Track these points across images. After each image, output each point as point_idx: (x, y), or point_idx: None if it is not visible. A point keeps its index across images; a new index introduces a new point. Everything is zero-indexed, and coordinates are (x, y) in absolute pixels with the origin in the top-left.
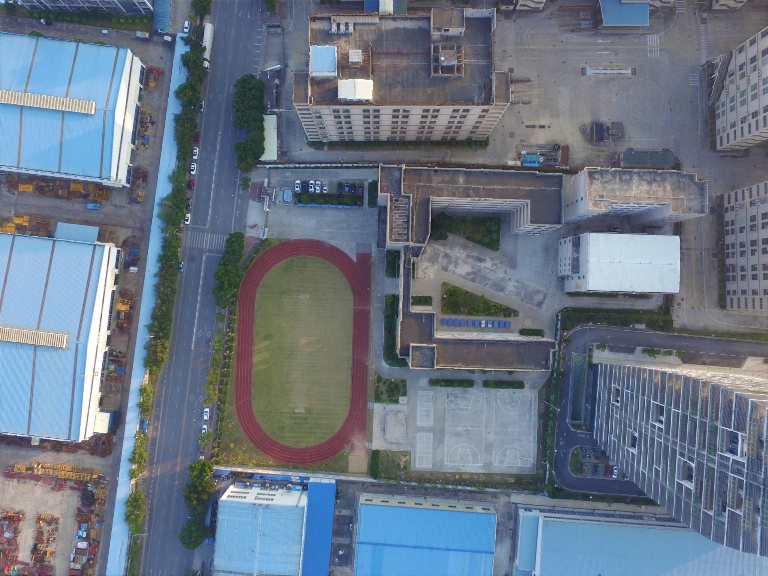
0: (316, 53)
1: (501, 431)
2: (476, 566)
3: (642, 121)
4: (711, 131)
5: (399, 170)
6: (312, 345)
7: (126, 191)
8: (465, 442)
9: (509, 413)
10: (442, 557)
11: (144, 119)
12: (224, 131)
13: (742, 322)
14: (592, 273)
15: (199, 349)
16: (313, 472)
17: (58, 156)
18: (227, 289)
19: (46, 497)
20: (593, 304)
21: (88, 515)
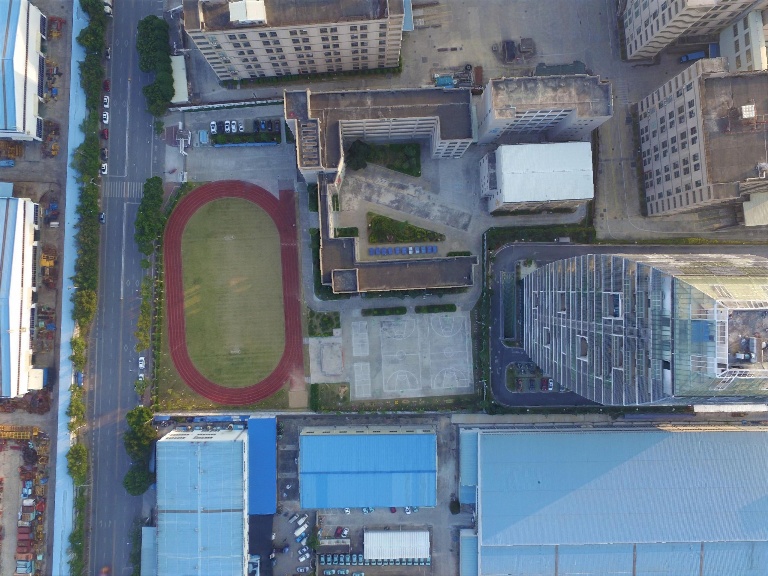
0: None
1: (437, 355)
2: (419, 486)
3: (553, 36)
4: (621, 41)
5: (304, 95)
6: (242, 286)
7: (39, 146)
8: (402, 368)
9: (443, 336)
10: (385, 480)
11: (50, 71)
12: (134, 77)
13: (664, 228)
14: (507, 185)
15: (129, 299)
16: (254, 411)
17: None
18: (149, 234)
19: None
20: (518, 222)
21: (32, 473)
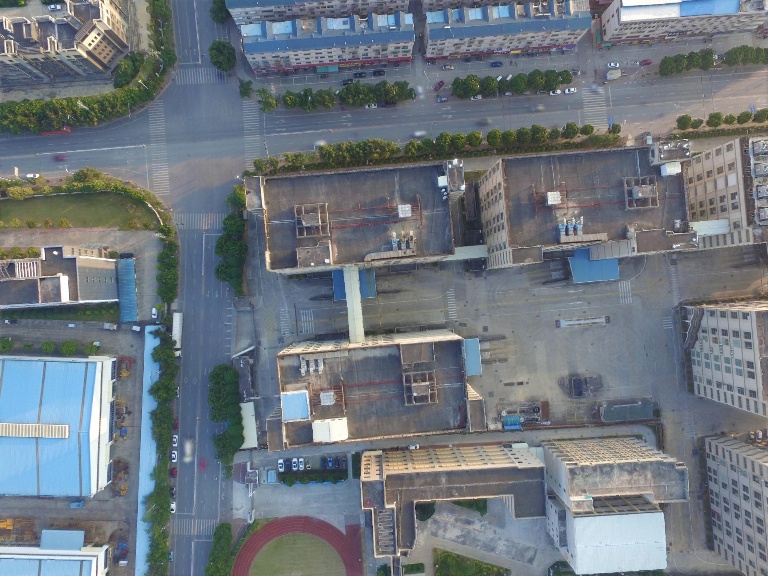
0: (287, 401)
1: None
2: None
3: (619, 369)
4: (688, 374)
5: (381, 483)
6: None
7: (108, 485)
8: None
9: None
10: None
11: (120, 410)
12: (202, 415)
13: None
14: (580, 558)
15: None
16: None
17: (36, 480)
18: None
19: None
20: None
21: None
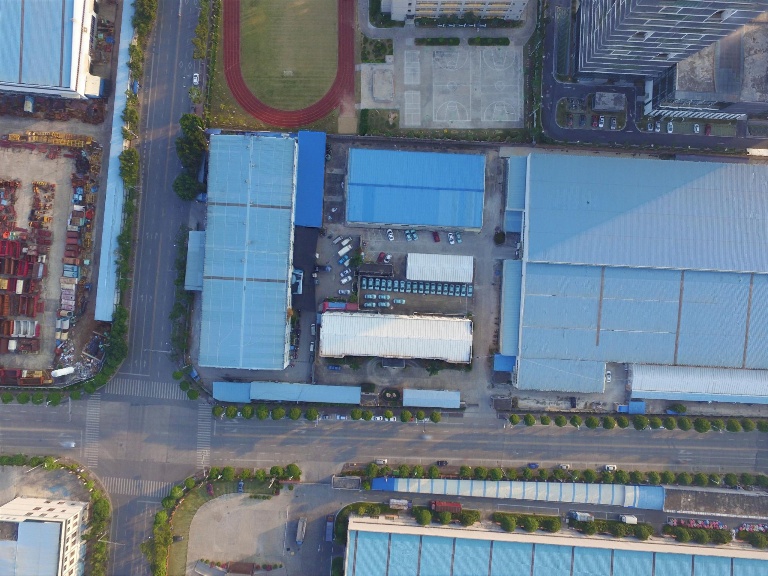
0: None
1: (488, 87)
2: (466, 205)
3: None
4: None
5: None
6: (298, 10)
7: None
8: (452, 99)
9: (495, 70)
10: (433, 196)
11: None
12: None
13: None
14: None
15: (186, 17)
16: None
17: None
18: None
19: (41, 165)
20: None
21: (83, 181)
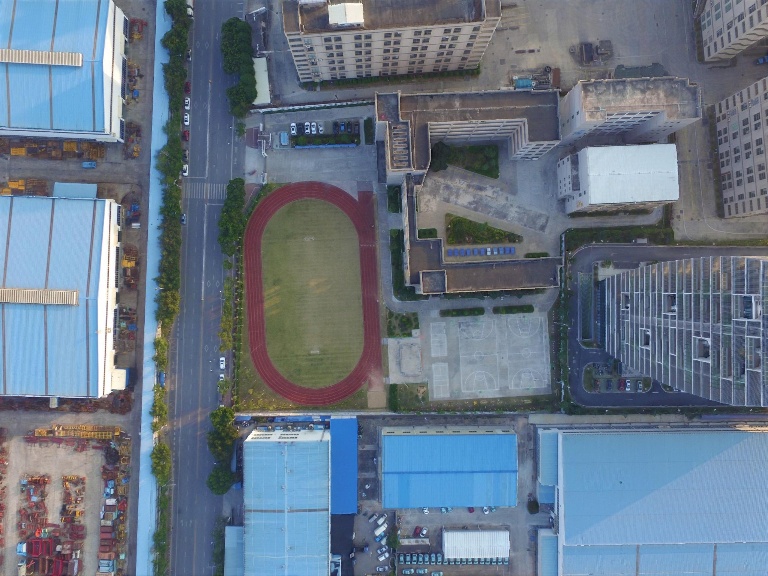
0: None
1: (514, 355)
2: (501, 485)
3: (630, 38)
4: (698, 43)
5: (395, 97)
6: (321, 286)
7: (120, 147)
8: (480, 369)
9: (521, 337)
10: (467, 480)
11: (132, 73)
12: (214, 79)
13: (740, 229)
14: (593, 187)
15: (209, 300)
16: (333, 411)
17: (49, 112)
18: (232, 235)
19: (70, 459)
20: (595, 223)
21: (114, 472)
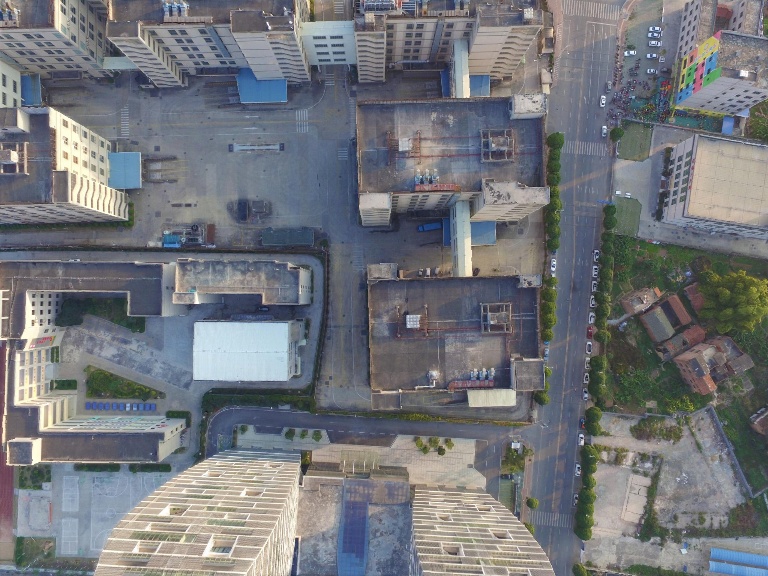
0: None
1: None
2: None
3: (290, 197)
4: None
5: None
6: None
7: None
8: (111, 527)
9: None
10: None
11: None
12: None
13: None
14: (197, 363)
15: None
16: None
17: None
18: None
19: None
20: (241, 384)
21: None
